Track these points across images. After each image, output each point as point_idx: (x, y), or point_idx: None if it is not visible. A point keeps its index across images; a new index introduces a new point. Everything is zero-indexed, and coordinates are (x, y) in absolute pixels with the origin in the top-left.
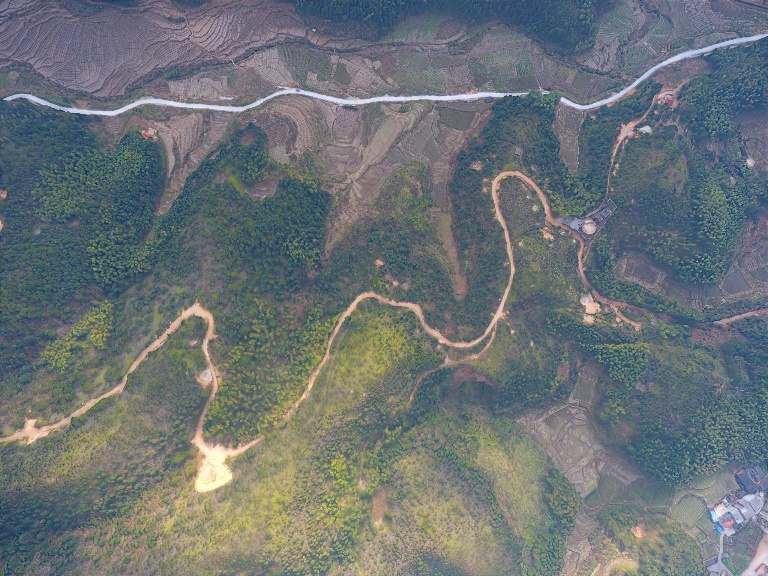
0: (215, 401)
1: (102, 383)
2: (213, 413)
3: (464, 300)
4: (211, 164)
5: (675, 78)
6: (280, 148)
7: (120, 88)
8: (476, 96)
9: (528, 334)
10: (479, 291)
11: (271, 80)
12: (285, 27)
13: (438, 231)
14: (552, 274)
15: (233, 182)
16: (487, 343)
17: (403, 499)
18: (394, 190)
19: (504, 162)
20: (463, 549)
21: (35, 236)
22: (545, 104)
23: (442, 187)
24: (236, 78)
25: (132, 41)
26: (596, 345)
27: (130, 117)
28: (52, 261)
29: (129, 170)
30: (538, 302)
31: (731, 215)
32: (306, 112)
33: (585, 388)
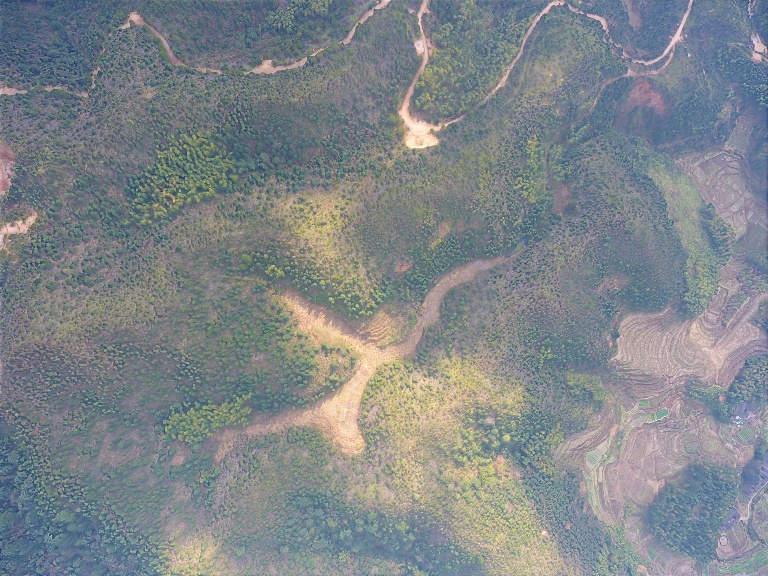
0: (428, 67)
1: (328, 39)
2: (427, 77)
3: (639, 30)
4: None
5: None
6: None
7: None
8: None
9: (701, 63)
10: (656, 19)
11: None
12: None
13: None
14: (731, 1)
15: None
16: (666, 62)
17: (589, 186)
18: None
19: None
20: (646, 231)
21: None
22: None
23: None
24: None
25: None
26: (761, 84)
27: None
28: None
29: None
30: (713, 32)
31: None
32: None
33: (741, 137)
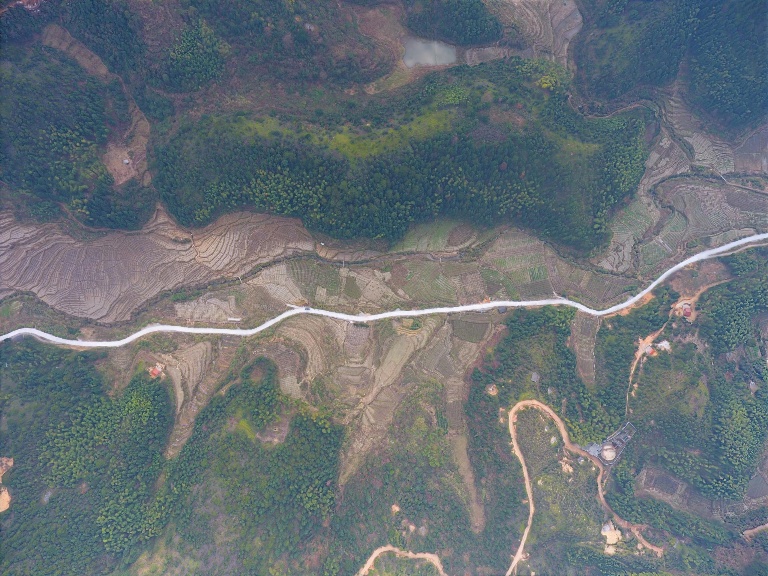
0: None
1: None
2: None
3: (482, 535)
4: (221, 406)
5: (692, 285)
6: (291, 378)
7: (126, 313)
8: (489, 305)
9: (548, 571)
10: (498, 529)
11: (279, 297)
12: (293, 241)
13: (453, 454)
14: (572, 514)
15: (244, 427)
16: None
17: None
18: (408, 419)
19: (520, 391)
20: None
21: (43, 508)
22: (561, 324)
23: (457, 406)
24: (244, 297)
25: (137, 264)
26: (618, 574)
27: (137, 352)
28: (62, 543)
29: (137, 420)
30: (558, 539)
31: (753, 432)
32: (316, 334)
33: None
